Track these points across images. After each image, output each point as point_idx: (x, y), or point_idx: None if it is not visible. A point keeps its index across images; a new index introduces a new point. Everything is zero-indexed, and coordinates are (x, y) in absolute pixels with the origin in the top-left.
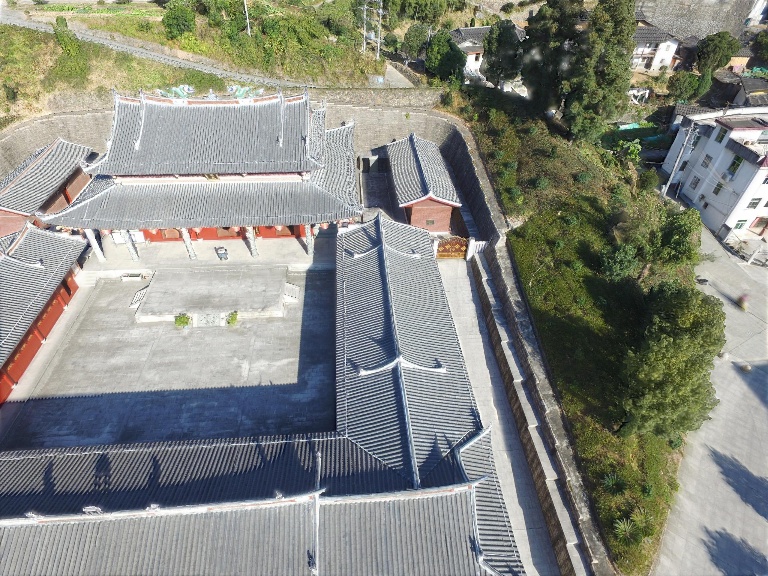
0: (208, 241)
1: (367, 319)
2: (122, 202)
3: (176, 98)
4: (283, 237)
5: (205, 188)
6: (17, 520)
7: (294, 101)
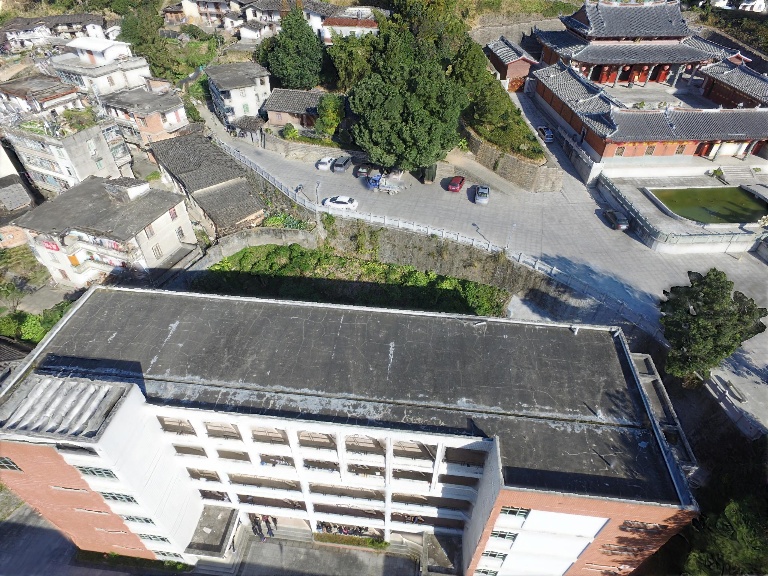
0: (611, 83)
1: (759, 86)
2: (597, 52)
3: (615, 2)
4: (649, 82)
5: (632, 47)
6: (715, 109)
7: (671, 4)
